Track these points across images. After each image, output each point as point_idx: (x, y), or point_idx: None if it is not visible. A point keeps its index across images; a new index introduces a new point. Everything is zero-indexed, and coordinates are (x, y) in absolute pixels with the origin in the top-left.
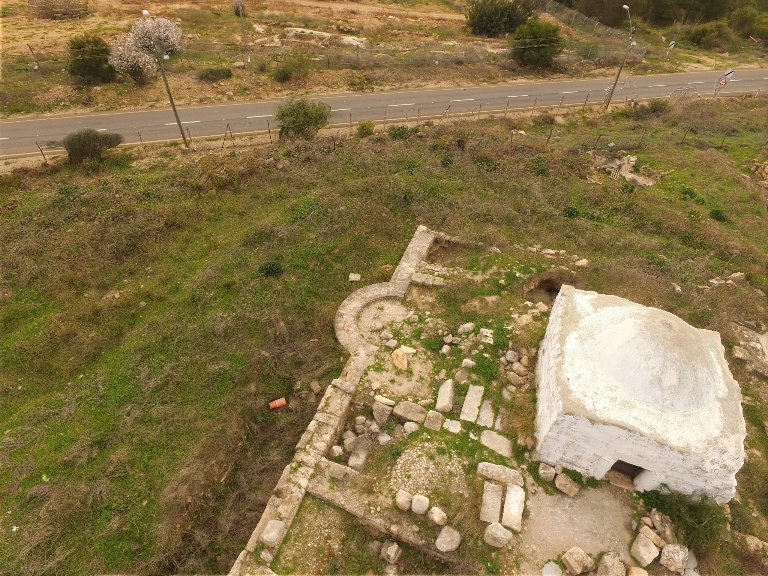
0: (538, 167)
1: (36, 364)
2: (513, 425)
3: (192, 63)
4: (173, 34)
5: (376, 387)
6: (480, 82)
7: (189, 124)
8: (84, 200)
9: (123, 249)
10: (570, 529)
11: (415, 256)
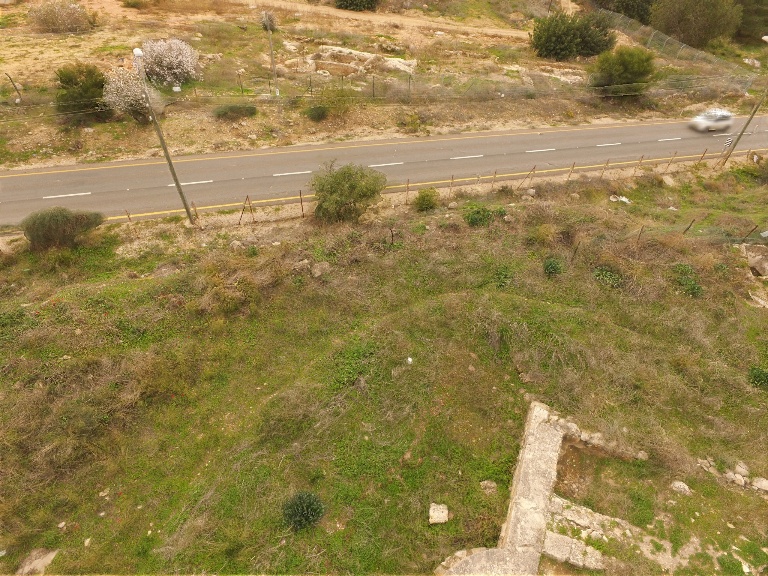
0: (686, 283)
1: None
2: None
3: (209, 94)
4: (188, 58)
5: None
6: (556, 122)
7: (198, 185)
8: (26, 343)
9: (66, 458)
10: None
11: (540, 483)
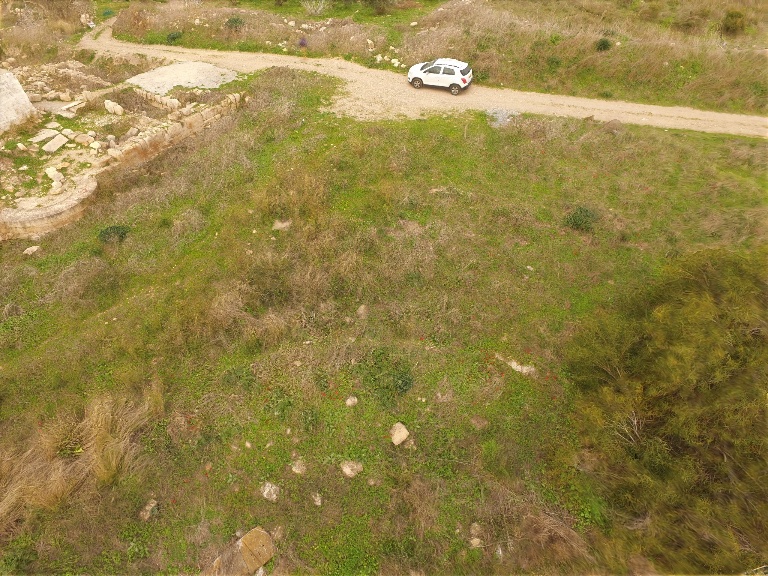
0: None
1: (328, 176)
2: (34, 124)
3: None
4: None
5: (94, 150)
6: None
7: None
8: None
9: None
10: (56, 105)
11: None
